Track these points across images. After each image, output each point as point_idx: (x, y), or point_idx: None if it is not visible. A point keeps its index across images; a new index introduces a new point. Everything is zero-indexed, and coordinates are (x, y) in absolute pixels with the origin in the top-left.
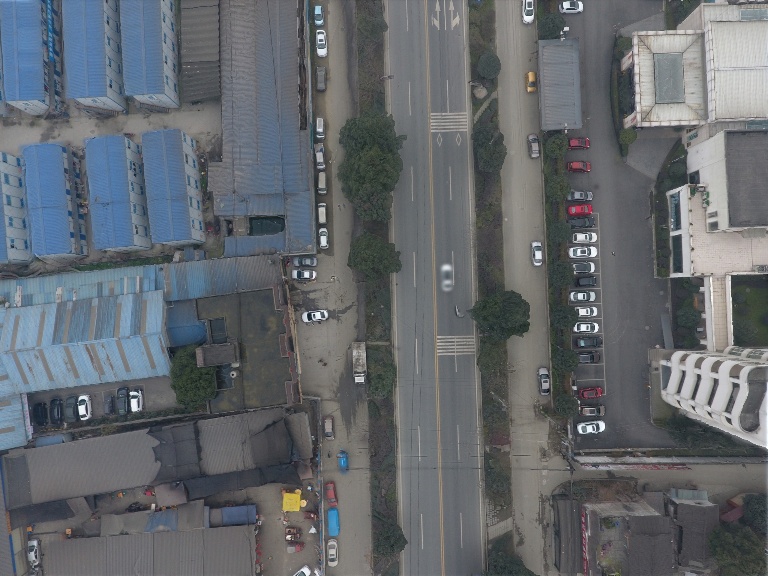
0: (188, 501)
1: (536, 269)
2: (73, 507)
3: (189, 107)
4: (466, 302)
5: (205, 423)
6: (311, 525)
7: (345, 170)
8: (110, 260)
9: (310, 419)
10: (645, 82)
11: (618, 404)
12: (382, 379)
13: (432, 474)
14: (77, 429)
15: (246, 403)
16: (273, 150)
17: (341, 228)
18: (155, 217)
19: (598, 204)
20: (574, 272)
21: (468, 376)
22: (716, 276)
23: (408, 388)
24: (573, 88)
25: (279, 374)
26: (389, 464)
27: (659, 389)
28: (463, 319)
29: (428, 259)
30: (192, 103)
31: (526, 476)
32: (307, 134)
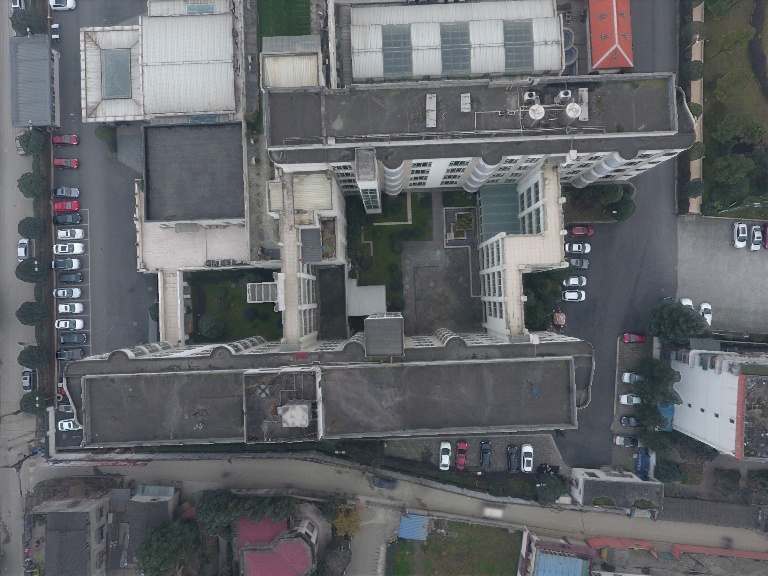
0: None
1: None
2: None
3: None
4: None
5: None
6: None
7: None
8: None
9: None
10: (92, 78)
11: None
12: None
13: None
14: None
15: None
16: None
17: None
18: None
19: (88, 201)
20: (35, 269)
21: None
22: (170, 271)
23: None
24: (46, 85)
25: None
26: None
27: None
28: None
29: None
30: None
31: (14, 473)
32: None
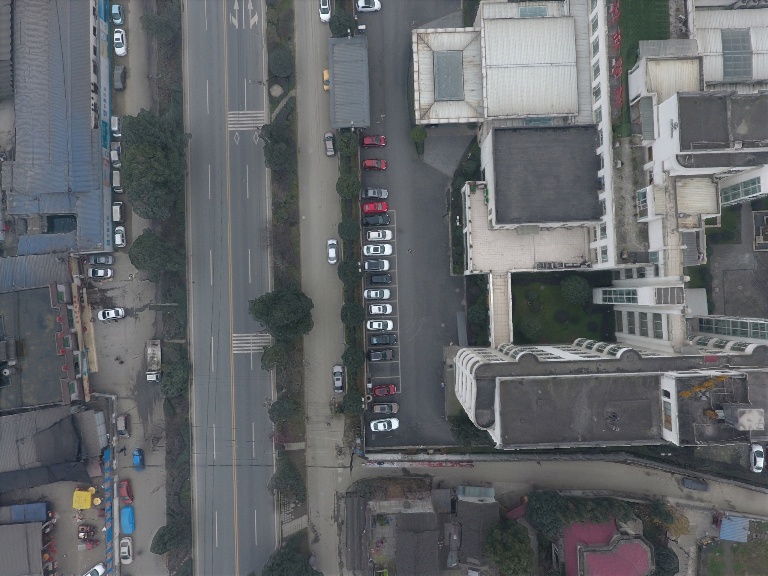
0: None
1: (333, 267)
2: None
3: None
4: None
5: None
6: None
7: None
8: None
9: (106, 417)
10: (424, 80)
11: (413, 401)
12: (171, 377)
13: (227, 472)
14: None
15: (23, 401)
16: (64, 149)
17: (139, 226)
18: None
19: (395, 202)
20: (359, 270)
21: (263, 374)
22: (498, 273)
23: (204, 386)
24: (363, 86)
25: (56, 372)
26: (183, 462)
27: (453, 386)
28: None
29: (224, 257)
30: None
31: (322, 474)
32: (98, 133)
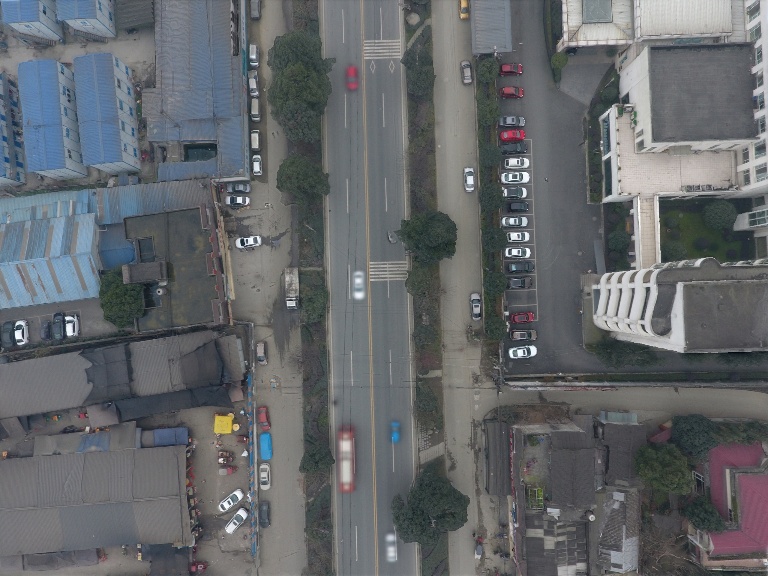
0: (120, 422)
1: (469, 195)
2: (7, 427)
3: (125, 36)
4: (399, 228)
5: (137, 345)
6: (244, 448)
7: (271, 90)
8: (47, 188)
9: (243, 344)
10: (572, 2)
11: (550, 329)
12: (312, 302)
13: (364, 399)
14: (12, 352)
15: (174, 322)
16: (205, 75)
17: (275, 155)
18: (86, 140)
19: (531, 130)
20: (503, 194)
21: (400, 302)
22: (644, 197)
23: (341, 313)
24: (504, 12)
25: (206, 293)
26: (321, 388)
27: (591, 314)
28: (396, 245)
29: (361, 185)
30: (127, 32)
31: (458, 401)
32: (239, 59)
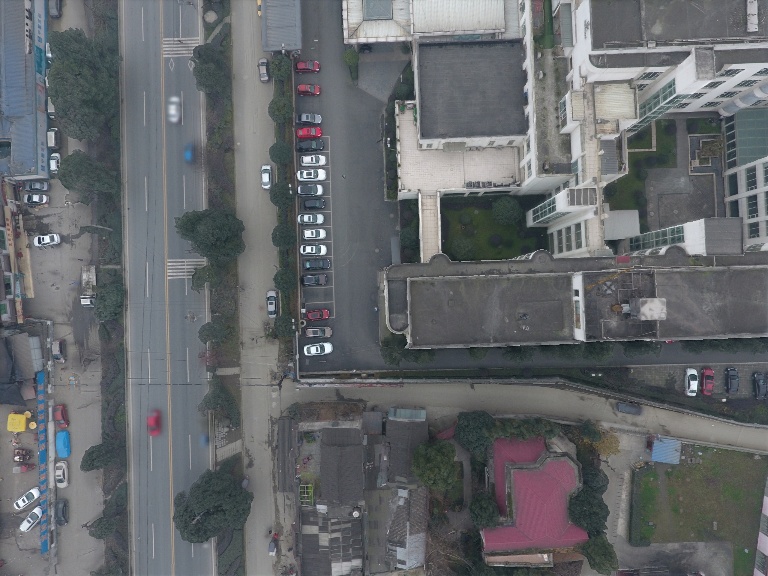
0: None
1: (267, 193)
2: None
3: None
4: None
5: None
6: None
7: None
8: None
9: (42, 342)
10: None
11: (347, 326)
12: (104, 300)
13: (161, 396)
14: None
15: None
16: None
17: None
18: None
19: (329, 127)
20: (290, 191)
21: (198, 299)
22: (428, 194)
23: (139, 311)
24: (294, 9)
25: None
26: (118, 386)
27: None
28: None
29: (159, 183)
30: None
31: (256, 399)
32: (31, 57)
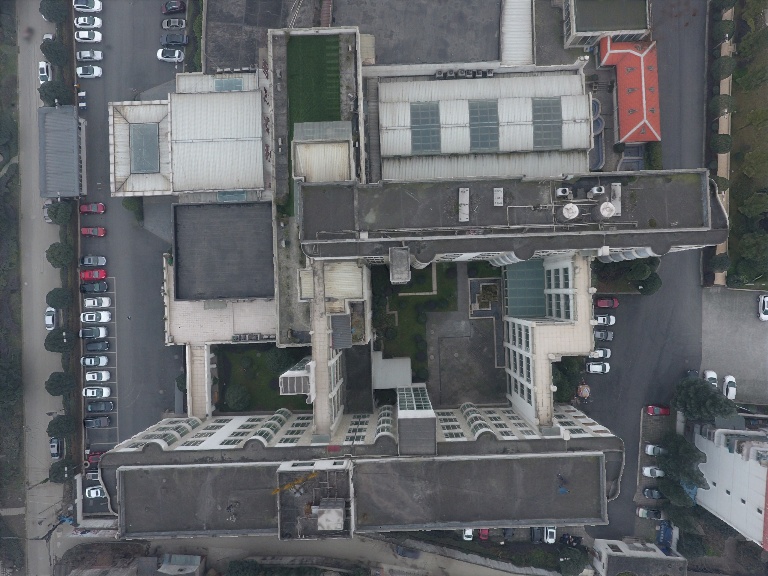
0: None
1: None
2: None
3: None
4: None
5: None
6: None
7: None
8: None
9: None
10: (121, 152)
11: None
12: None
13: None
14: None
15: None
16: None
17: None
18: None
19: (114, 268)
20: (64, 340)
21: None
22: (198, 345)
23: None
24: (73, 155)
25: None
26: None
27: None
28: None
29: None
30: None
31: None
32: None
